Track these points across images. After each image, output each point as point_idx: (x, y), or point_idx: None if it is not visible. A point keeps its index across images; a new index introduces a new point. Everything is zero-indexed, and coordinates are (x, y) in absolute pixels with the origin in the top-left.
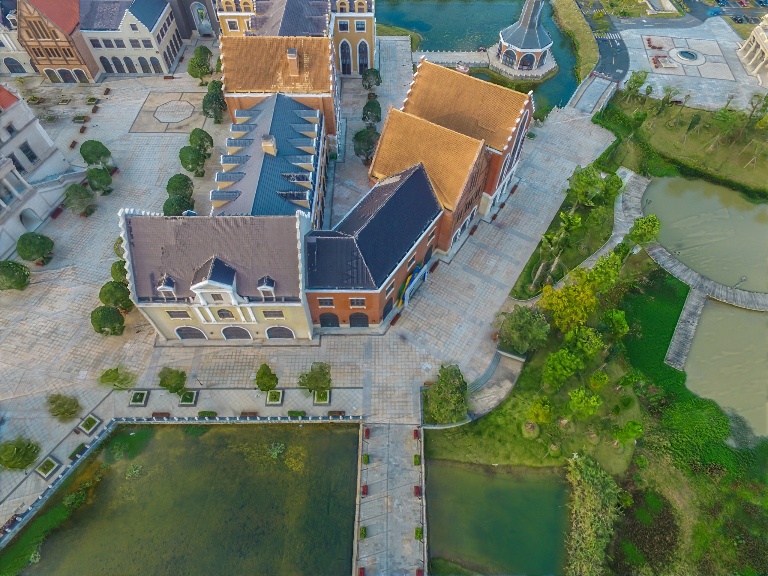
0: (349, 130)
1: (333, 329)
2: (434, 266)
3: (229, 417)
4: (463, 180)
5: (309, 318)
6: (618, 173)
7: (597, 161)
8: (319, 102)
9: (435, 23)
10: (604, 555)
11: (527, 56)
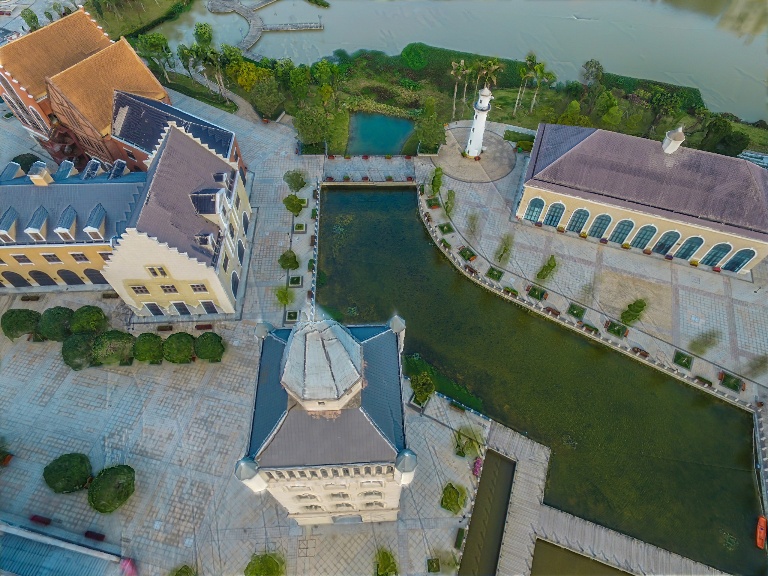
0: None
1: None
2: None
3: None
4: (145, 72)
5: None
6: None
7: None
8: None
9: None
10: None
11: None
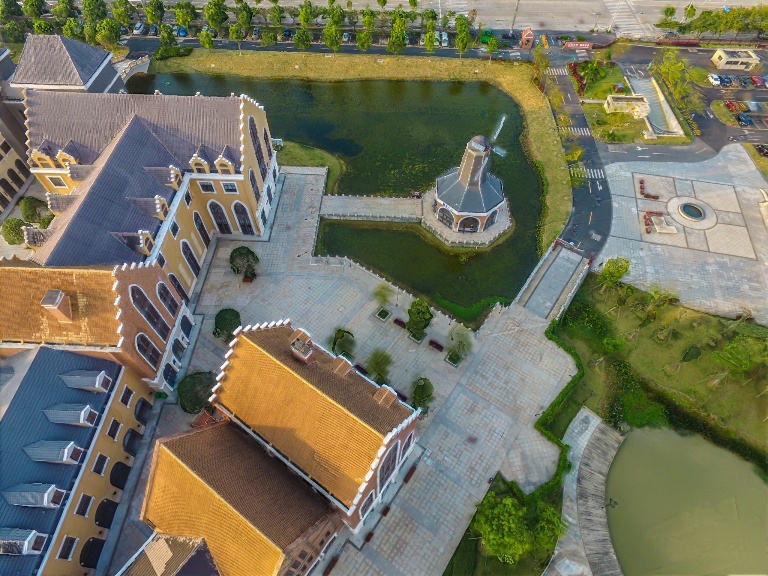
0: (201, 339)
1: None
2: None
3: None
4: None
5: None
6: (578, 420)
7: (542, 421)
8: (109, 355)
9: (368, 143)
10: None
11: (468, 219)
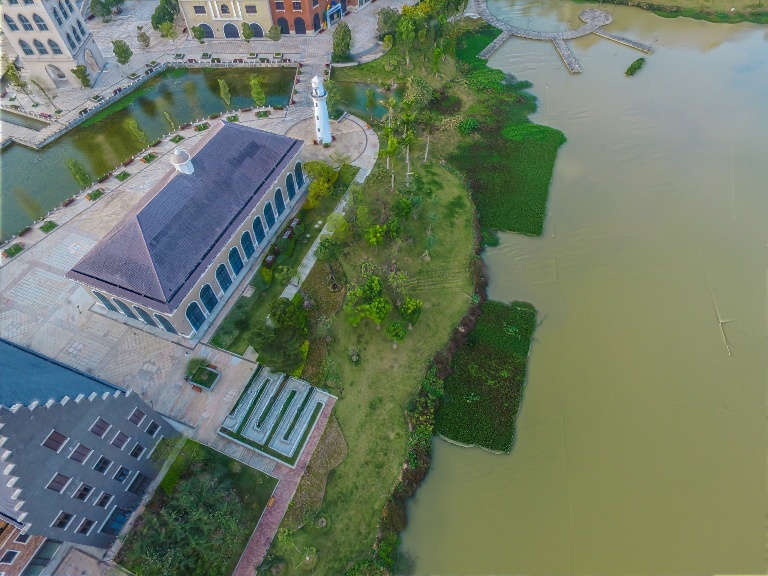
0: None
1: (286, 35)
2: (347, 13)
3: (228, 61)
4: None
5: (271, 19)
6: None
7: None
8: None
9: None
10: (419, 109)
11: None
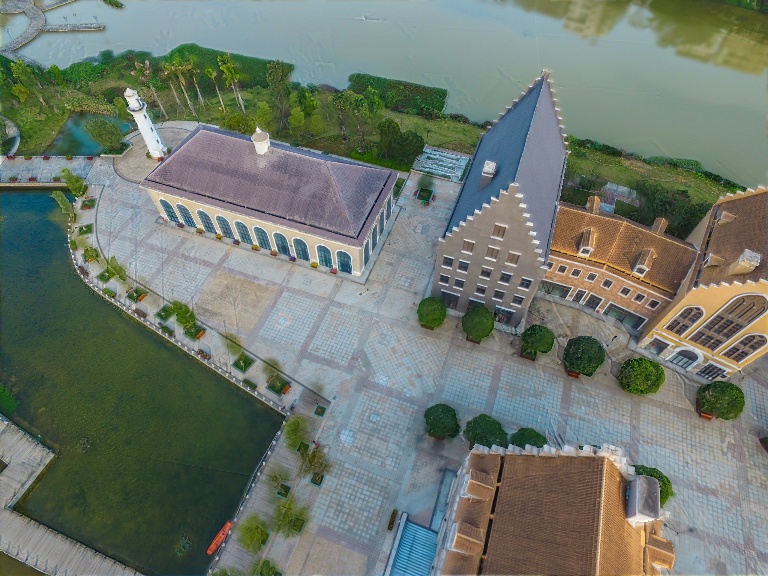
0: None
1: None
2: None
3: None
4: None
5: None
6: None
7: None
8: None
9: None
10: None
11: None
